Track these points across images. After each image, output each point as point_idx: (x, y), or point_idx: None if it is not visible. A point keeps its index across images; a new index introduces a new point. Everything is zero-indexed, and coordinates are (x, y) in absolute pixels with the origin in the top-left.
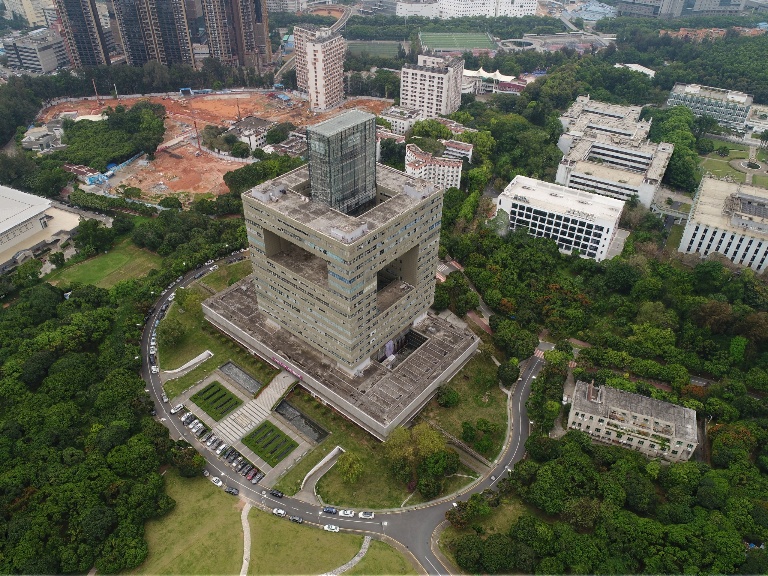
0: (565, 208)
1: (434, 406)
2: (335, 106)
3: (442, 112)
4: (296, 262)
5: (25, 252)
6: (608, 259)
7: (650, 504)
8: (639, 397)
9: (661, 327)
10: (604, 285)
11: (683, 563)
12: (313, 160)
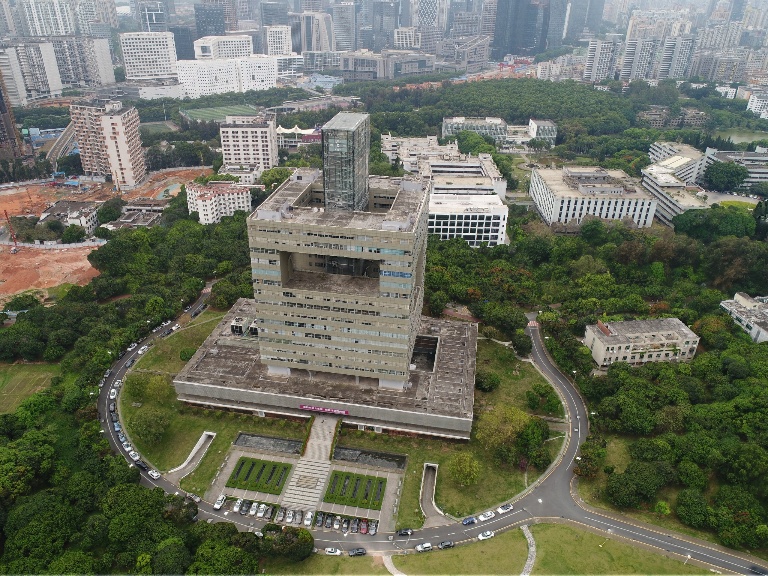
0: (460, 209)
1: (479, 395)
2: (143, 181)
3: (271, 165)
4: (316, 284)
5: None
6: (514, 241)
7: (704, 394)
8: (636, 322)
9: (599, 273)
10: (528, 259)
11: (764, 421)
12: (330, 162)
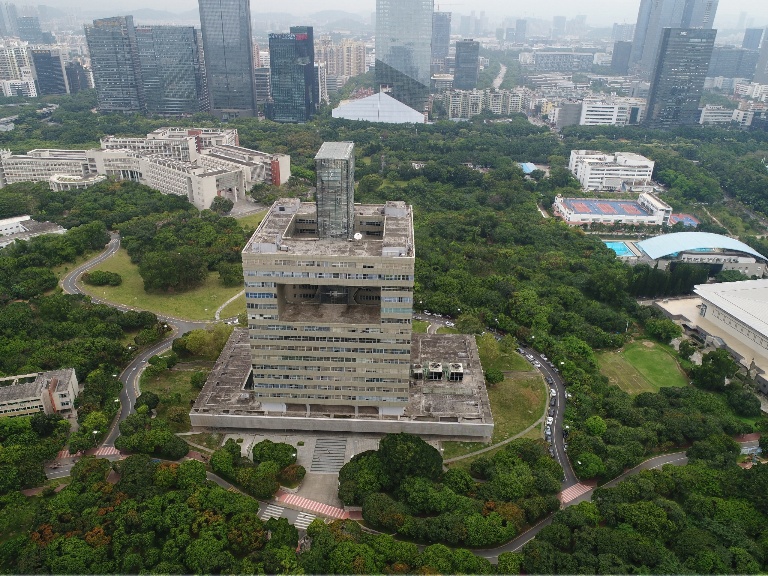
0: None
1: None
2: None
3: None
4: None
5: (716, 340)
6: None
7: None
8: None
9: None
10: None
11: None
12: None
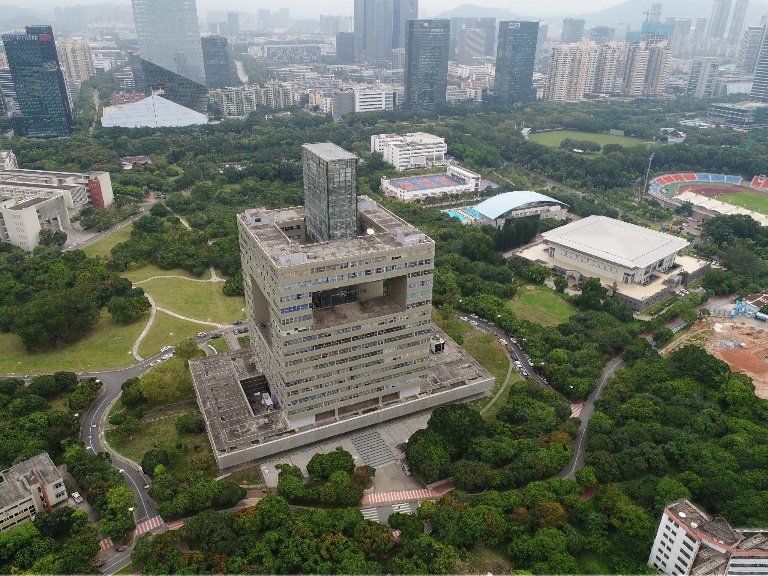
0: None
1: None
2: None
3: None
4: None
5: (575, 273)
6: None
7: None
8: None
9: None
10: None
11: None
12: None
